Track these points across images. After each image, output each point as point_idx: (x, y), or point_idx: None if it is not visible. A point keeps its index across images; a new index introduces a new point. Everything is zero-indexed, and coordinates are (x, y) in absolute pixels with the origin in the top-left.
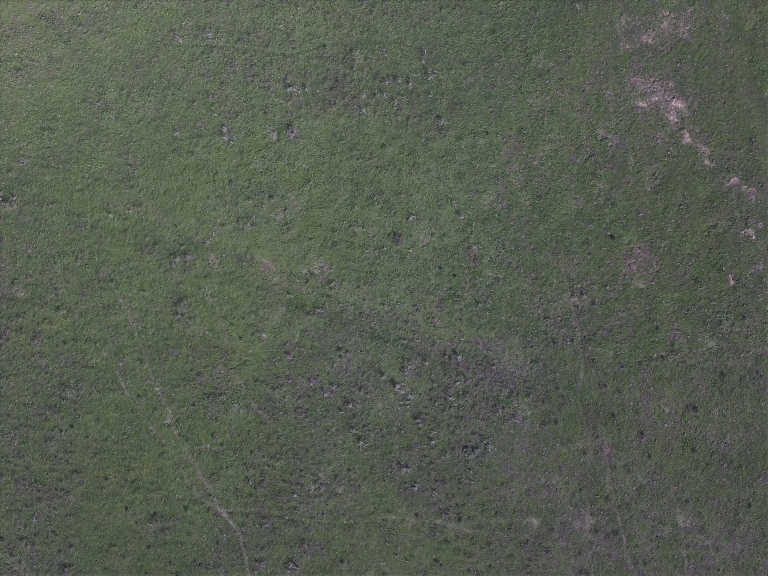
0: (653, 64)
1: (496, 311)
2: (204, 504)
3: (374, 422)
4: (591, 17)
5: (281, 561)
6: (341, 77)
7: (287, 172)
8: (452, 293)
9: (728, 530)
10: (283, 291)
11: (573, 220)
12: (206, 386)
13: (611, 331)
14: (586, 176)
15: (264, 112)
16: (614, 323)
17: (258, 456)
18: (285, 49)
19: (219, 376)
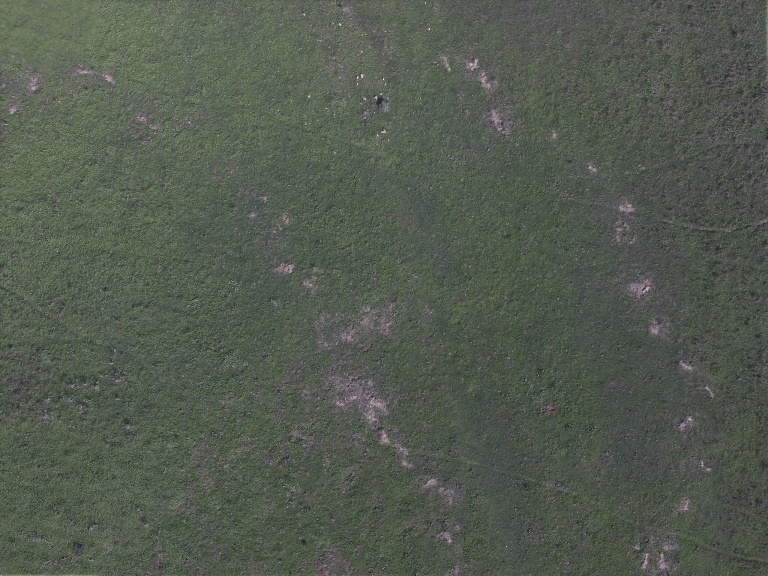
0: (352, 362)
1: None
2: None
3: None
4: (289, 314)
5: None
6: (26, 378)
7: None
8: None
9: None
10: None
11: (264, 525)
12: None
13: None
14: (278, 479)
15: None
16: None
17: None
18: None
19: None
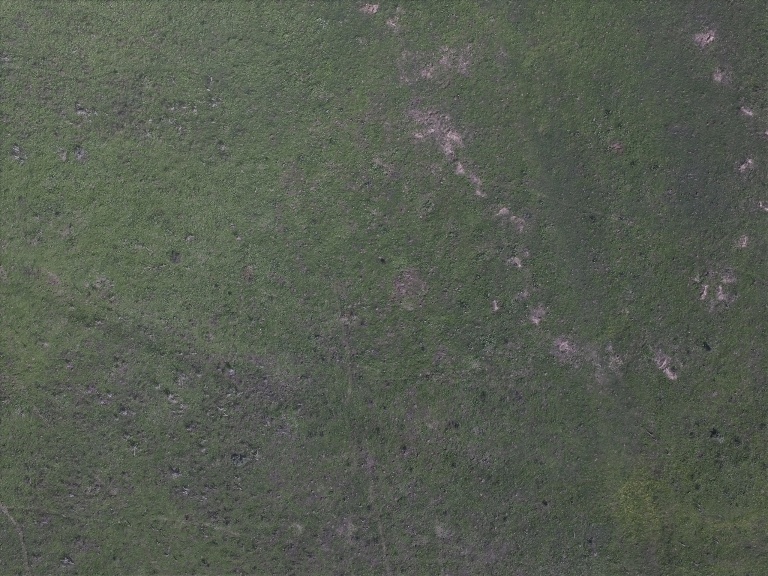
0: (431, 97)
1: (269, 328)
2: None
3: (148, 429)
4: (373, 51)
5: (58, 556)
6: (130, 102)
7: (74, 191)
8: (227, 310)
9: (484, 542)
10: (66, 303)
11: (346, 244)
12: None
13: (379, 350)
14: (360, 203)
15: (55, 133)
16: (382, 343)
17: (39, 457)
18: (78, 73)
19: (4, 381)
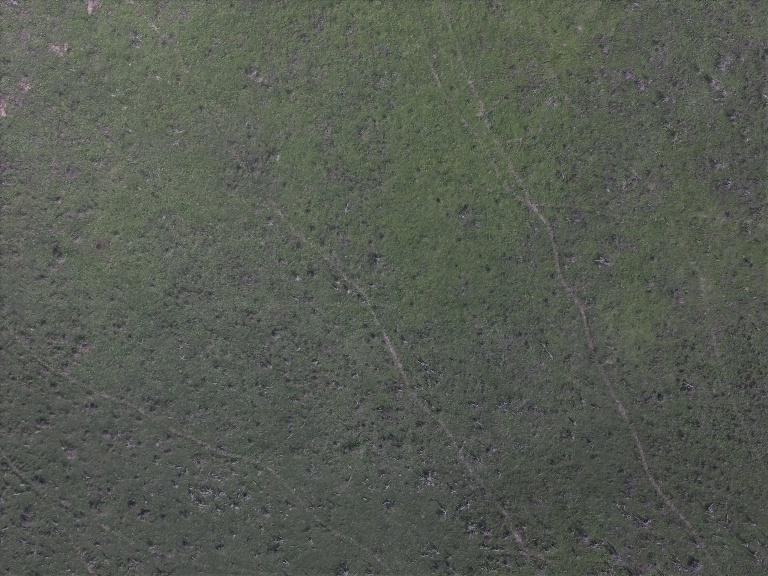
0: None
1: None
2: (515, 198)
3: (688, 119)
4: None
5: (591, 257)
6: None
7: None
8: None
9: None
10: None
11: None
12: (520, 80)
13: None
14: None
15: None
16: None
17: (571, 151)
18: None
19: (533, 70)
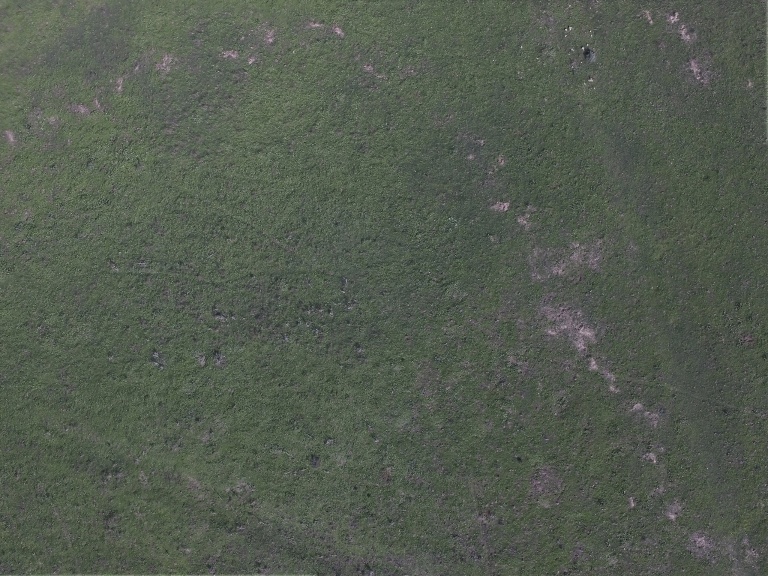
0: (563, 294)
1: (407, 529)
2: None
3: None
4: (504, 248)
5: None
6: (266, 305)
7: (213, 396)
8: (366, 512)
9: None
10: (207, 508)
11: (482, 443)
12: None
13: (517, 549)
14: (496, 401)
15: (193, 338)
16: (520, 541)
17: None
18: (214, 278)
19: None
